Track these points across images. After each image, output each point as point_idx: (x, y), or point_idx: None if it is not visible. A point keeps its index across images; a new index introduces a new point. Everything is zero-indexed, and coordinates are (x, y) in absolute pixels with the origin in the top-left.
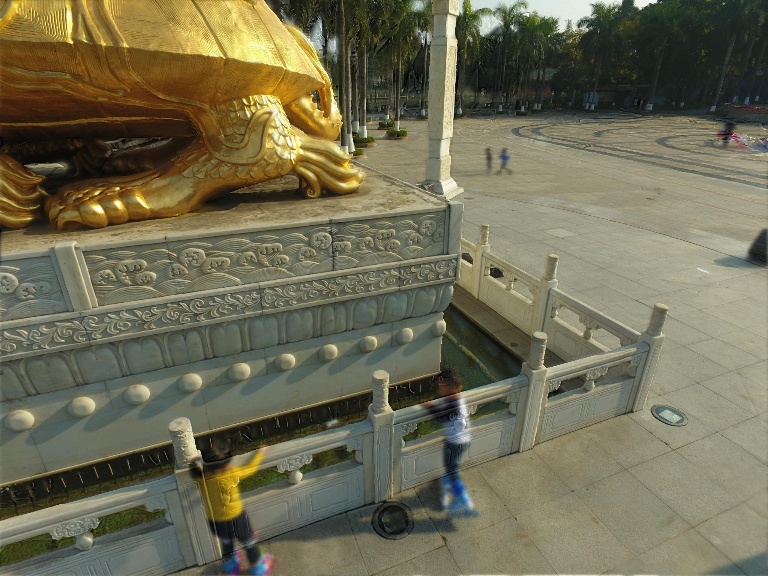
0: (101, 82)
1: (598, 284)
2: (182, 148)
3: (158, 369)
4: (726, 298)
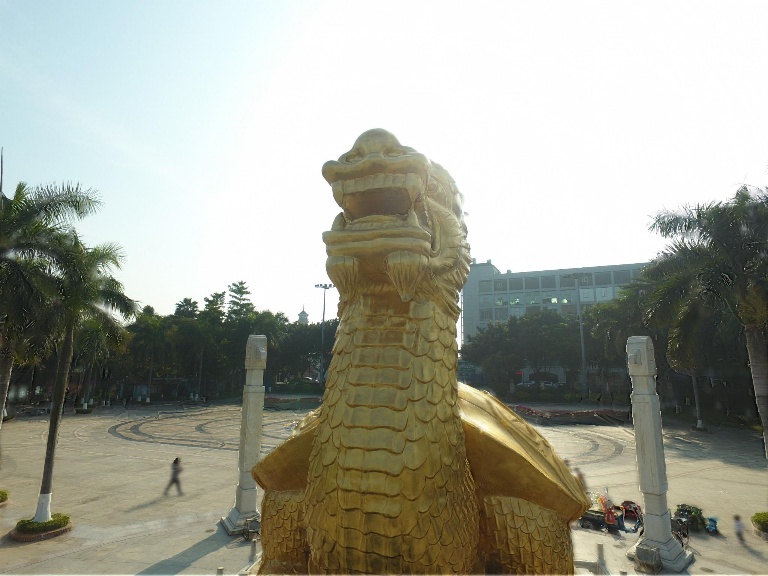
0: None
1: None
2: None
3: None
4: None
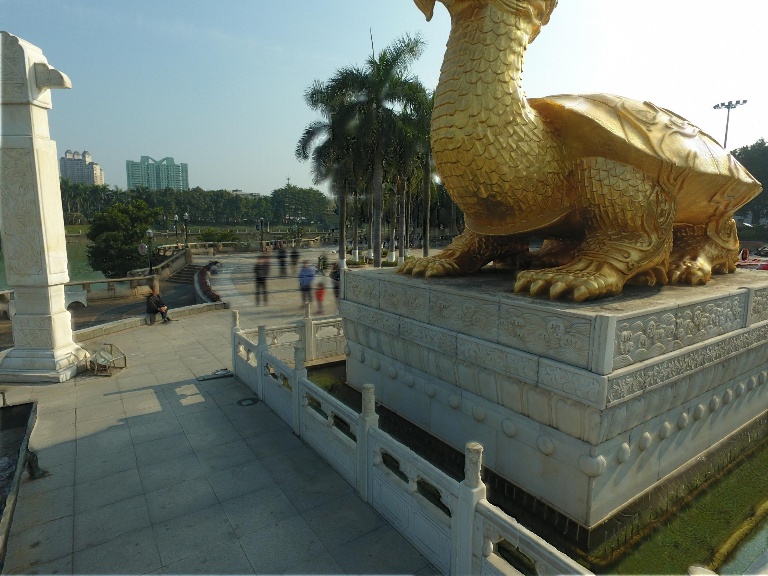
0: (733, 202)
1: None
2: (573, 249)
3: (746, 372)
4: None
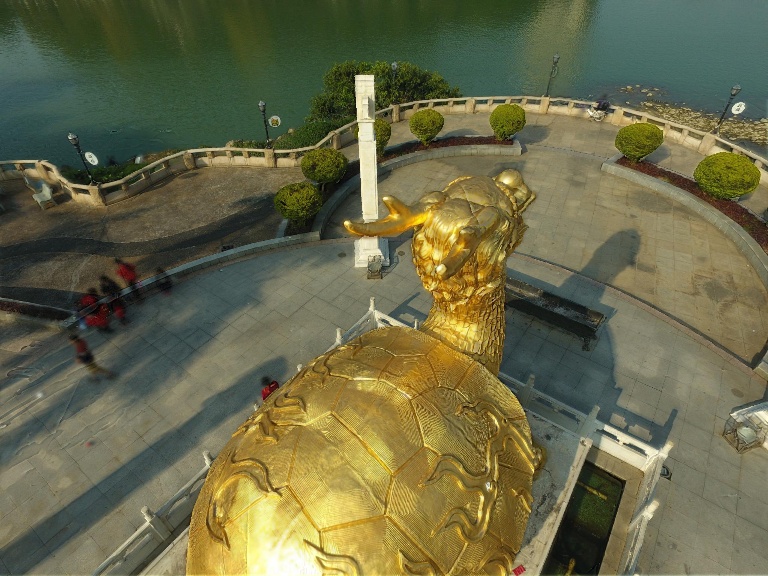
0: None
1: None
2: None
3: None
4: None
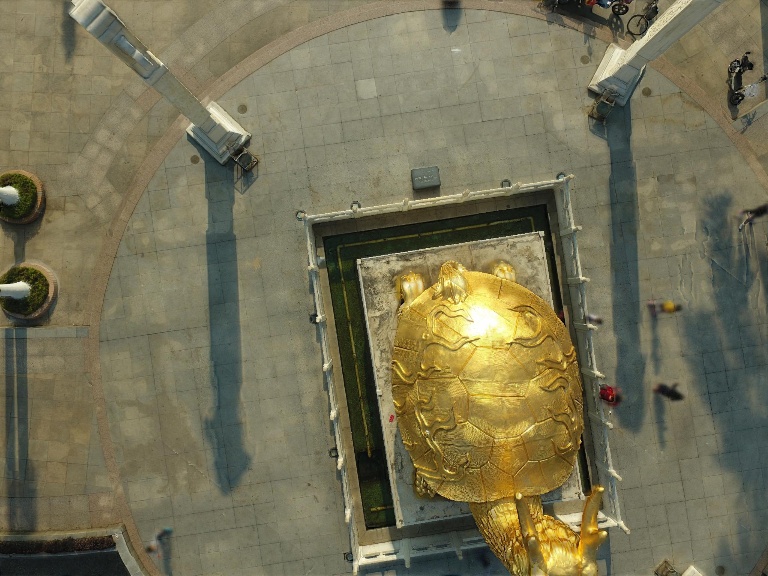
0: None
1: (460, 127)
2: None
3: None
4: (491, 73)
